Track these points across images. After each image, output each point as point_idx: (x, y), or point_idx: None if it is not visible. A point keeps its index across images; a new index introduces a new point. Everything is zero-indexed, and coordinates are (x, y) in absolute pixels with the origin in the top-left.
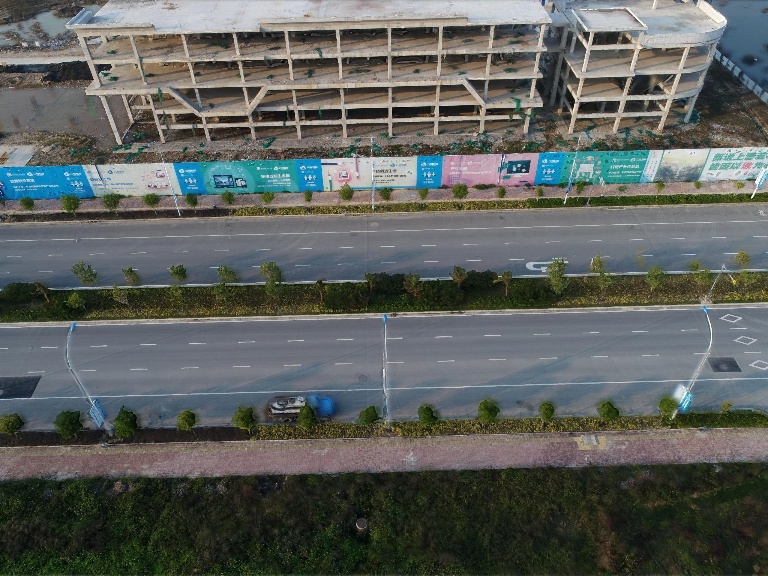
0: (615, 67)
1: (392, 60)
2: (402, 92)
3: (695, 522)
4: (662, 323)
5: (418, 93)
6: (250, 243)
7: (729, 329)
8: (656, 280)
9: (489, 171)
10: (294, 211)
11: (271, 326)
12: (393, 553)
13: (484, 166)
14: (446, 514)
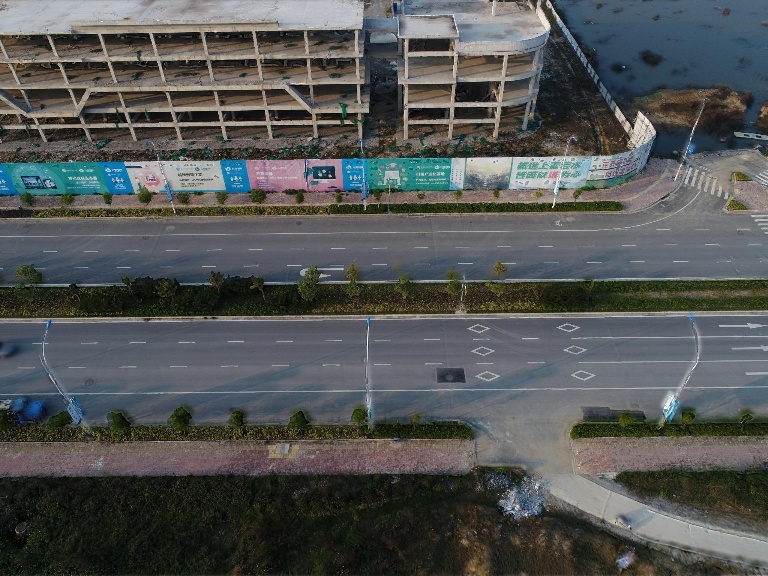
0: (440, 74)
1: (251, 63)
2: (235, 96)
3: (347, 533)
4: (408, 332)
5: (250, 97)
6: (40, 245)
7: (472, 339)
8: (404, 289)
9: (295, 176)
10: (96, 213)
11: (22, 328)
12: (39, 558)
13: (289, 171)
14: (108, 520)
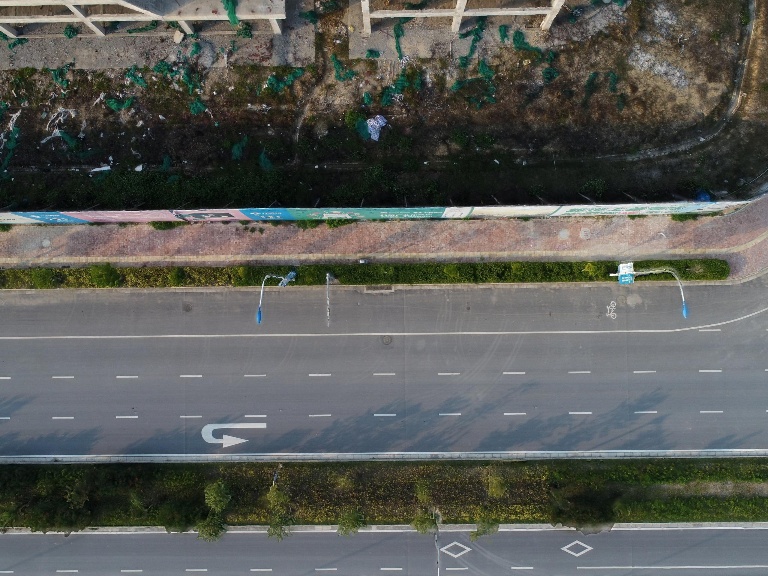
0: None
1: None
2: None
3: None
4: (360, 556)
5: None
6: None
7: (444, 569)
8: None
9: (162, 217)
10: None
11: None
12: None
13: (147, 215)
14: None
